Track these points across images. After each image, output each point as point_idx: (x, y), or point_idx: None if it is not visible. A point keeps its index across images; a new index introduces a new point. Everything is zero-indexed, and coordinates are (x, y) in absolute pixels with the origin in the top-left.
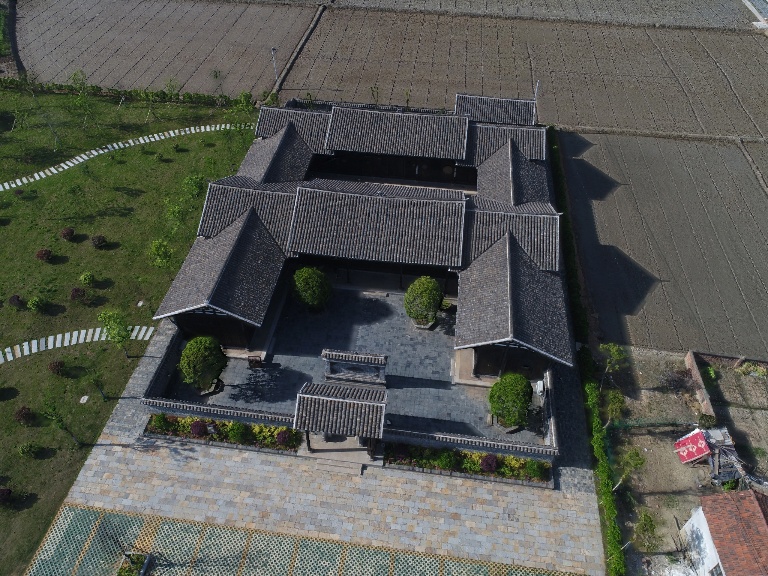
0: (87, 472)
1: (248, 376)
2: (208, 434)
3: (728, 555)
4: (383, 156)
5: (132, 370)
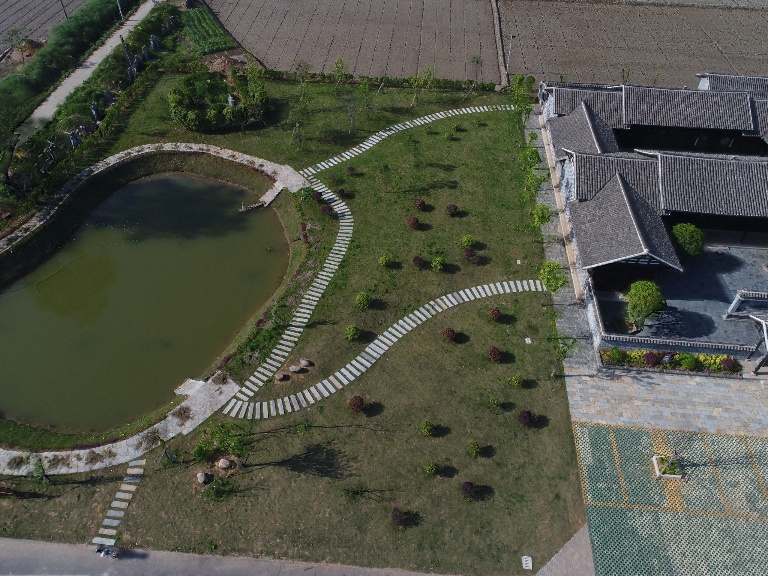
0: (574, 397)
1: (655, 318)
2: (660, 363)
3: None
4: (670, 129)
5: (552, 316)
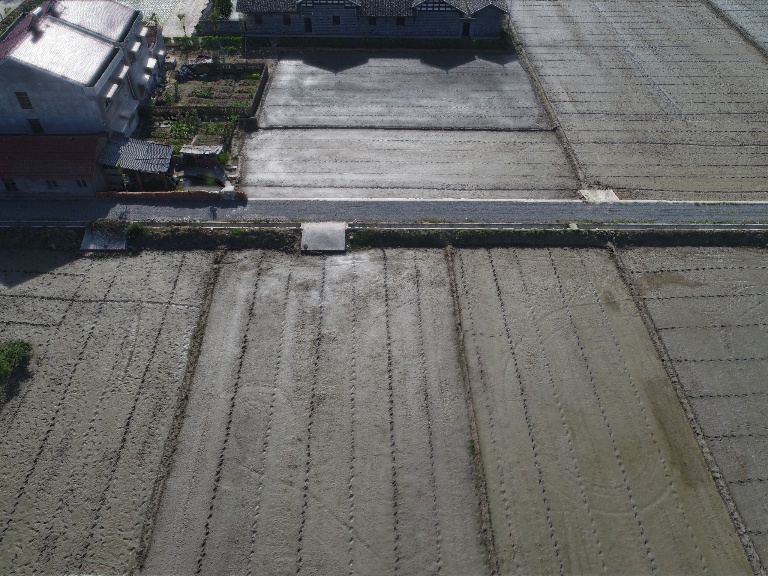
0: None
1: None
2: None
3: None
4: None
5: None
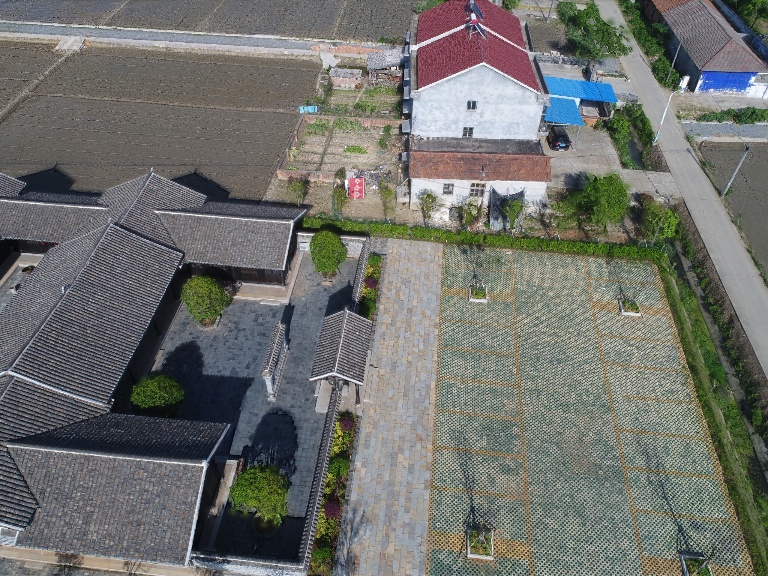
0: None
1: None
2: (338, 500)
3: (444, 174)
4: None
5: None
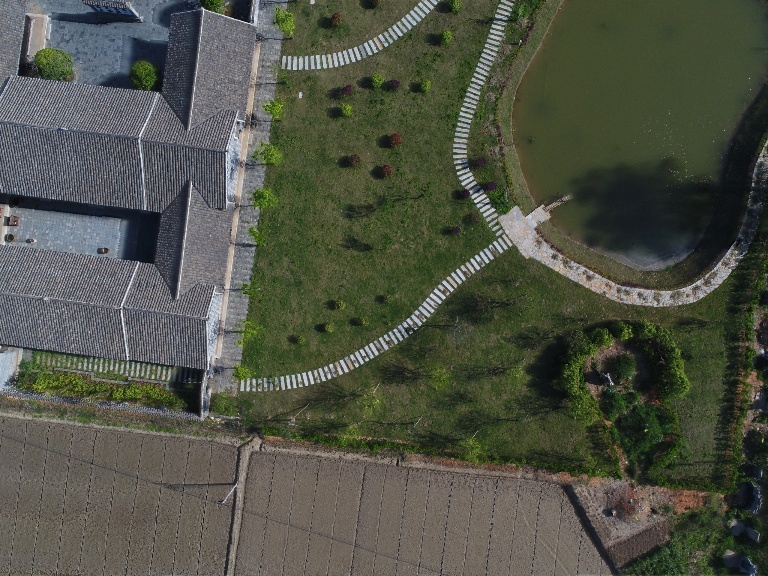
0: None
1: None
2: None
3: None
4: None
5: None
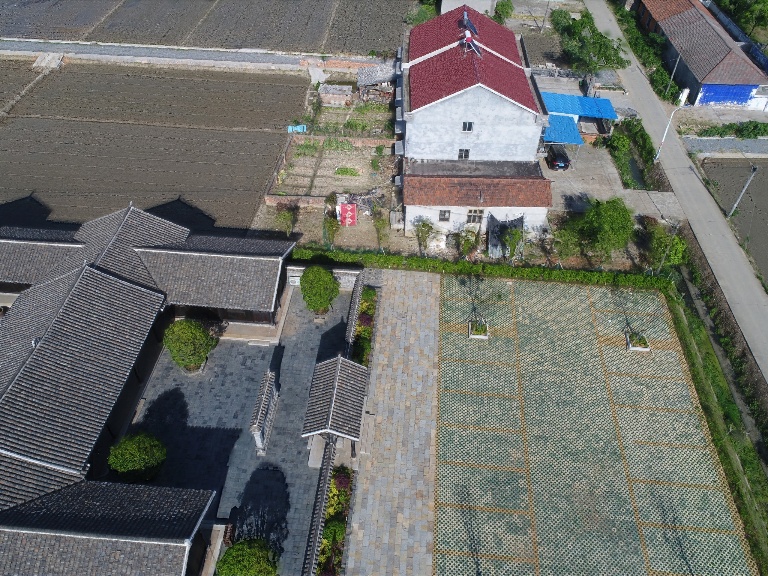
0: None
1: None
2: (334, 569)
3: (440, 201)
4: None
5: None
